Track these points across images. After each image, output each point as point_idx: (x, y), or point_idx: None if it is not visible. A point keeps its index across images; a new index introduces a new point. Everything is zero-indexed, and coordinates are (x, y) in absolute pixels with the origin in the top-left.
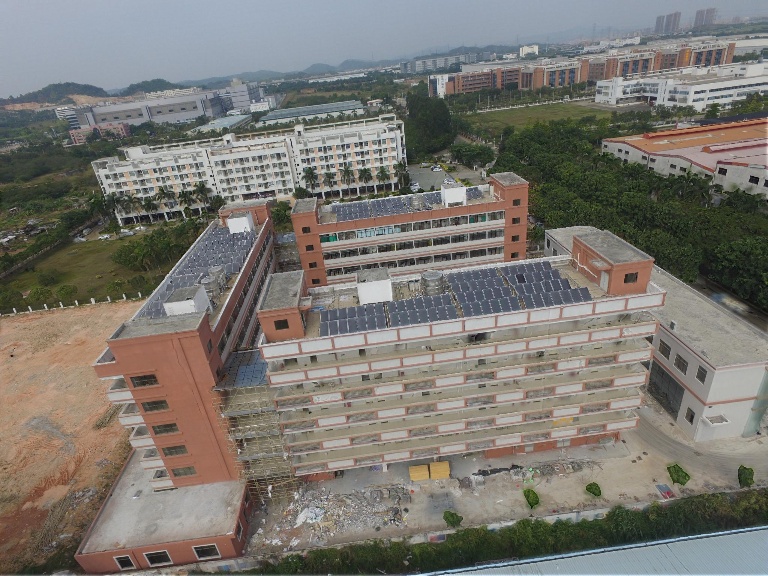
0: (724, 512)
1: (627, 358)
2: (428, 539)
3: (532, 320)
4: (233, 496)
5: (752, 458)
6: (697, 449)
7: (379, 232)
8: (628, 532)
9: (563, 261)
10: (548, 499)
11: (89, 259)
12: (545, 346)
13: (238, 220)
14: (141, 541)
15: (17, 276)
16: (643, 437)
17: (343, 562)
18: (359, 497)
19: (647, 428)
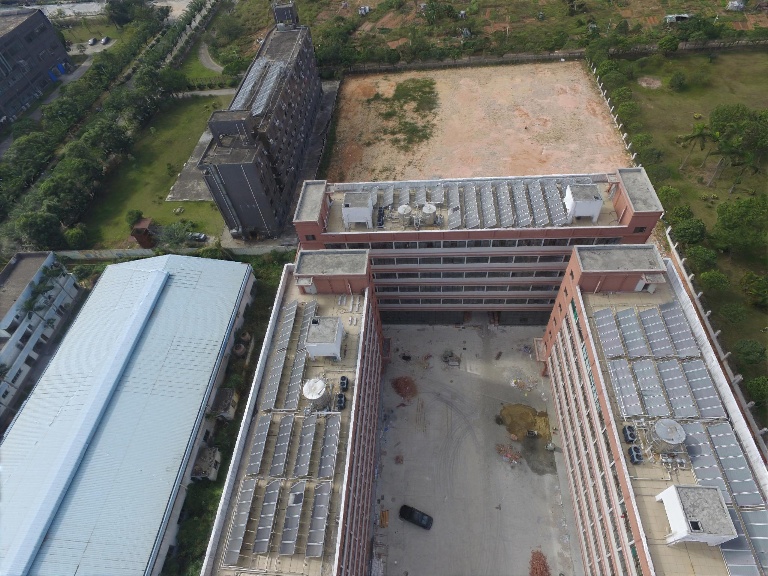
0: None
1: None
2: None
3: None
4: None
5: None
6: None
7: None
8: (189, 571)
9: None
10: None
11: (756, 87)
12: None
13: (571, 196)
14: None
15: (697, 56)
16: None
17: None
18: None
19: None
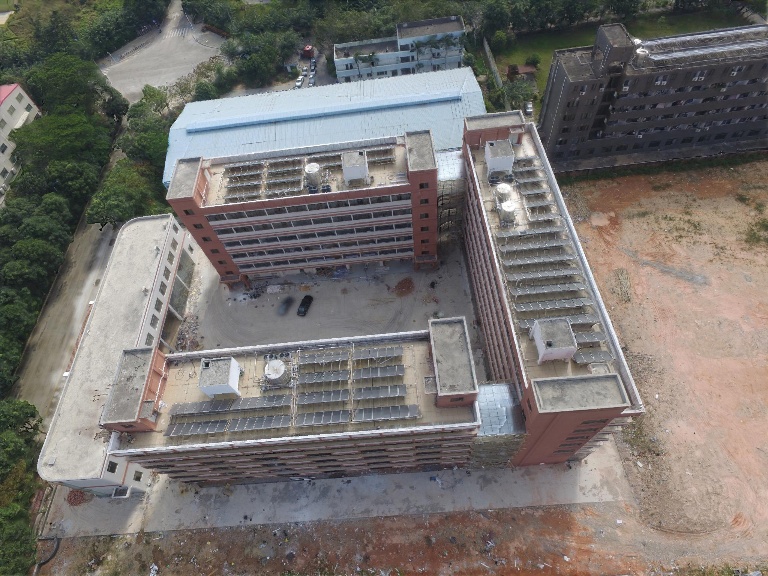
0: None
1: None
2: None
3: None
4: None
5: None
6: None
7: None
8: None
9: None
10: None
11: None
12: None
13: None
14: None
15: None
16: None
17: None
18: None
19: None
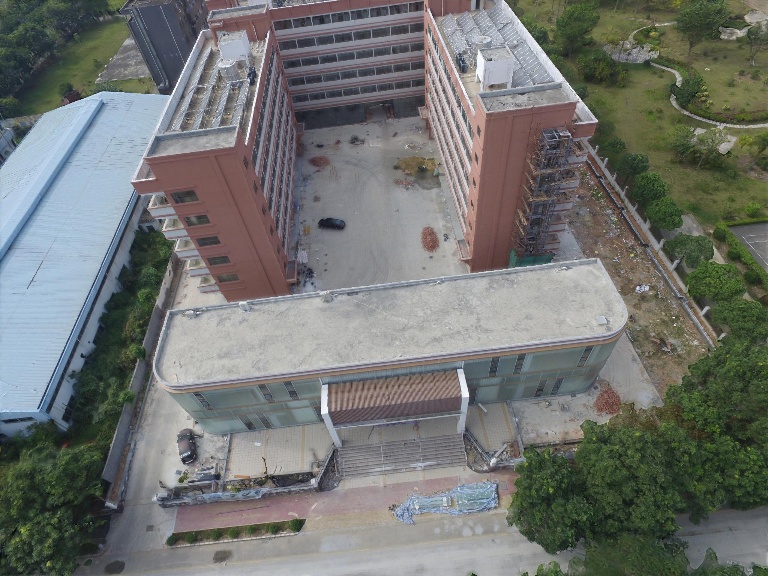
0: None
1: None
2: None
3: None
4: None
5: None
6: None
7: None
8: None
9: None
10: None
11: None
12: None
13: None
14: None
15: None
16: None
17: None
18: None
19: None
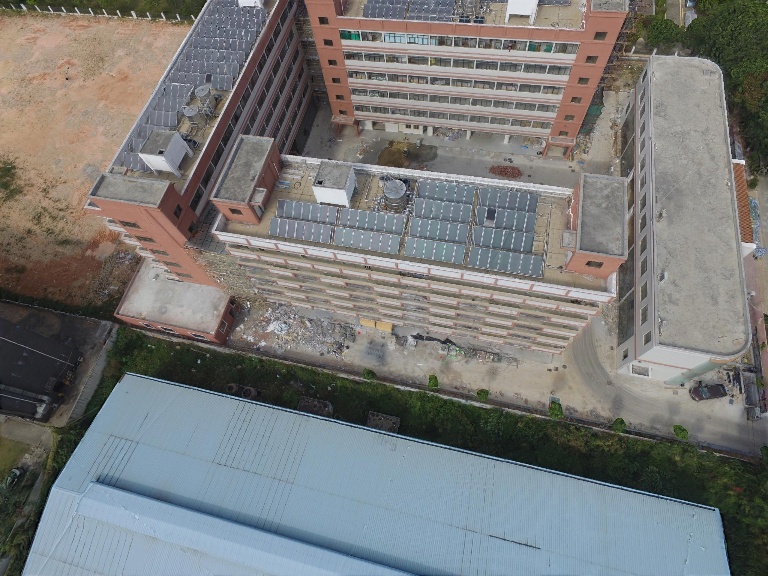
0: (575, 444)
1: (560, 321)
2: (351, 378)
3: (466, 278)
4: (220, 303)
5: (653, 404)
6: (613, 379)
7: (411, 40)
8: (490, 431)
9: (561, 194)
10: (457, 376)
11: None
12: (478, 295)
13: None
14: (155, 317)
15: None
16: (575, 351)
17: (288, 372)
18: (318, 324)
19: (586, 344)
